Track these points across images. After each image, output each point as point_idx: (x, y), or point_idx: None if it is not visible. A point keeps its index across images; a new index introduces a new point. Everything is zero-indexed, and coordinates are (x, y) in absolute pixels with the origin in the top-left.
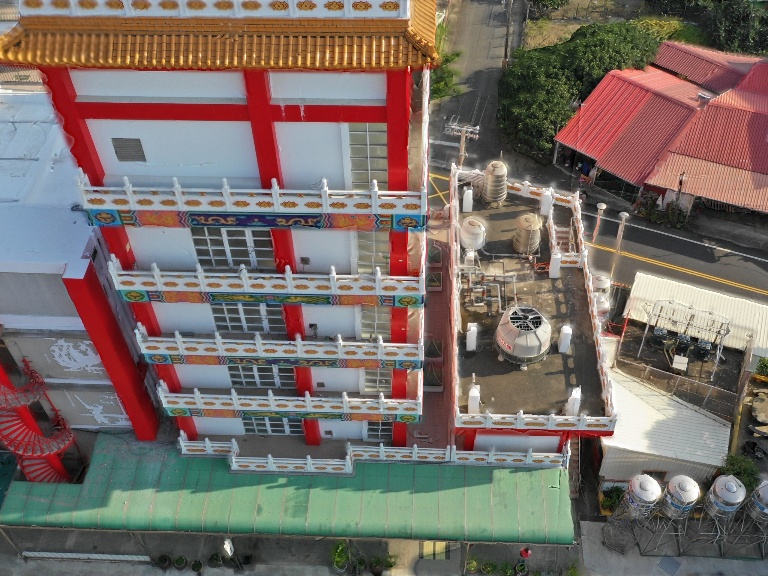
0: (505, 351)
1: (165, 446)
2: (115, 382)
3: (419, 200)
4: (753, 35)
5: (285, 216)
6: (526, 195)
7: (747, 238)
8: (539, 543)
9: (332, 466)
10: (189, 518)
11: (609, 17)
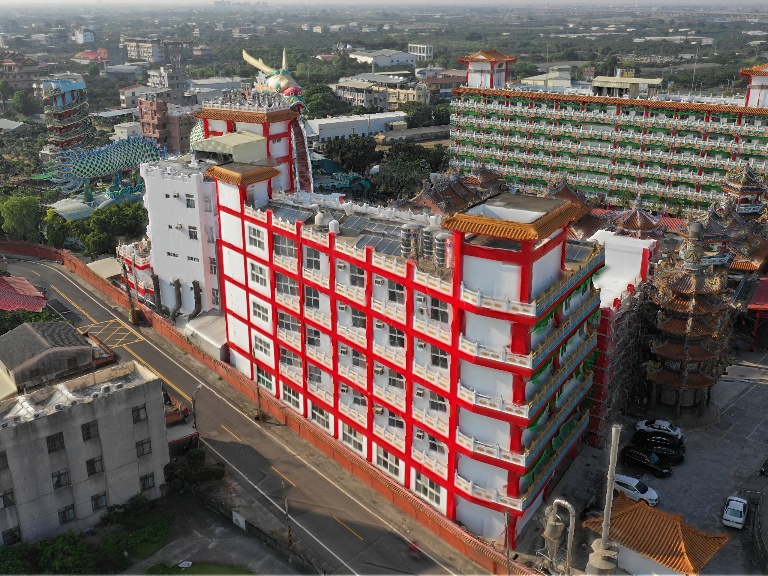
0: None
1: None
2: None
3: None
4: None
5: None
6: None
7: None
8: None
9: None
10: None
11: None
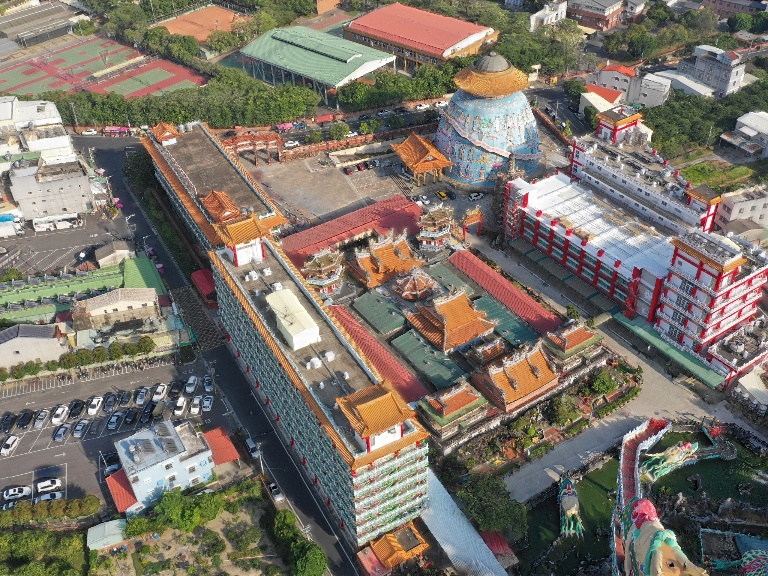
0: (730, 347)
1: (651, 325)
2: (652, 304)
3: (716, 294)
4: None
5: None
6: None
7: None
8: (707, 384)
9: None
10: (646, 337)
11: None
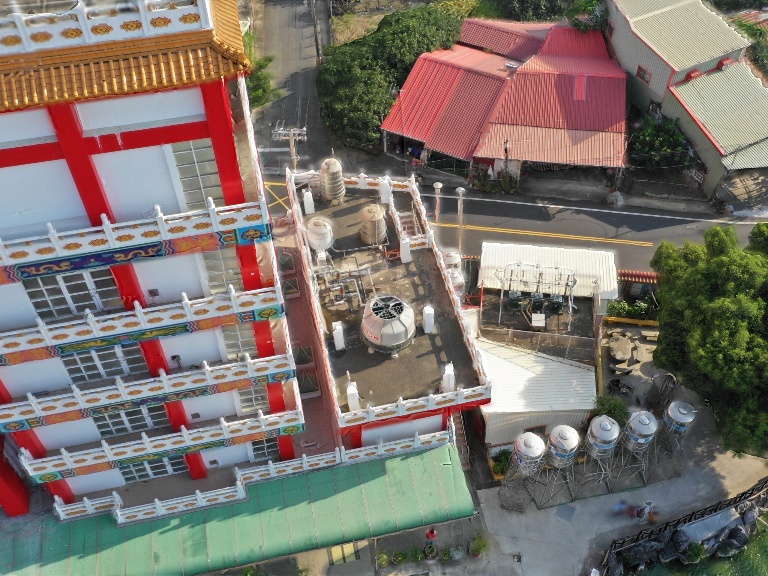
0: (374, 343)
1: (41, 516)
2: None
3: (259, 210)
4: (544, 2)
5: (123, 251)
6: (364, 187)
7: (575, 192)
8: (442, 522)
9: (224, 495)
10: None
11: (410, 3)
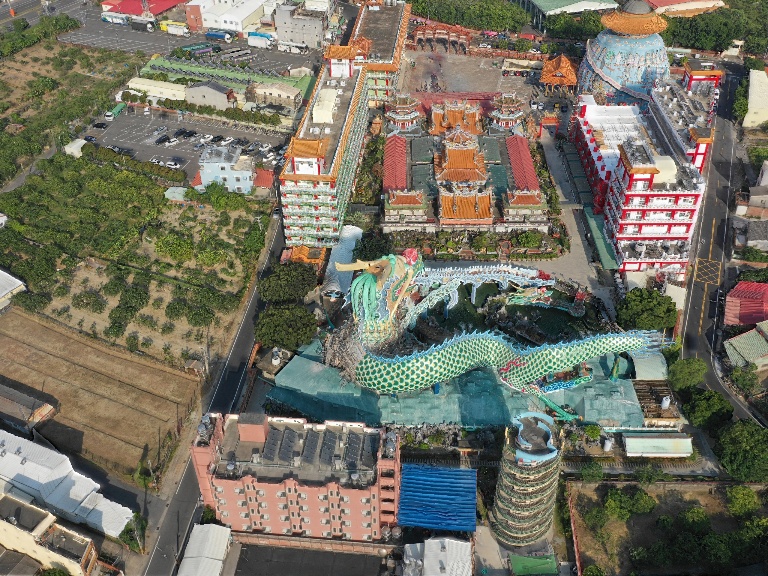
0: None
1: None
2: None
3: None
4: None
5: None
6: None
7: None
8: None
9: None
10: None
11: None
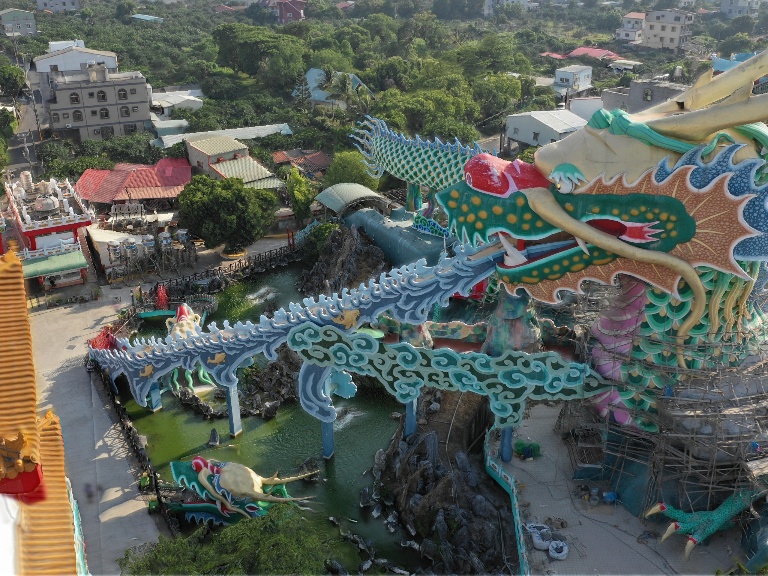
0: (40, 211)
1: None
2: None
3: None
4: None
5: None
6: None
7: None
8: (73, 268)
9: None
10: None
11: None
